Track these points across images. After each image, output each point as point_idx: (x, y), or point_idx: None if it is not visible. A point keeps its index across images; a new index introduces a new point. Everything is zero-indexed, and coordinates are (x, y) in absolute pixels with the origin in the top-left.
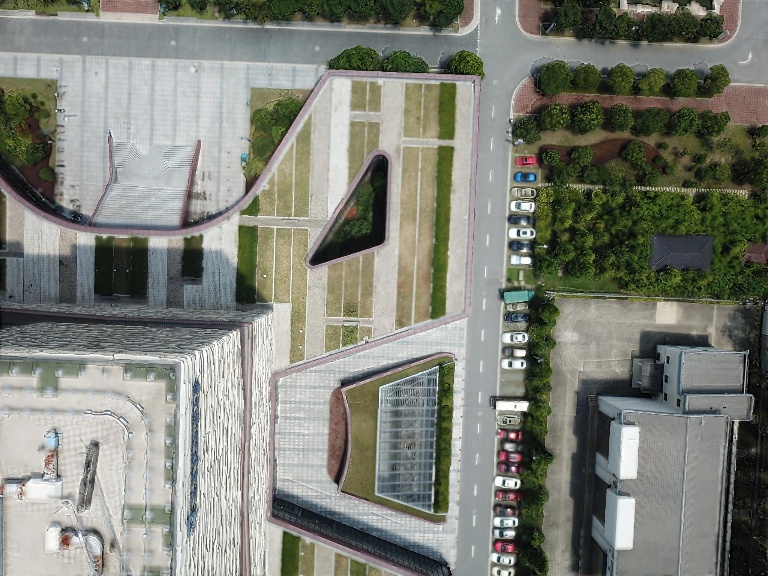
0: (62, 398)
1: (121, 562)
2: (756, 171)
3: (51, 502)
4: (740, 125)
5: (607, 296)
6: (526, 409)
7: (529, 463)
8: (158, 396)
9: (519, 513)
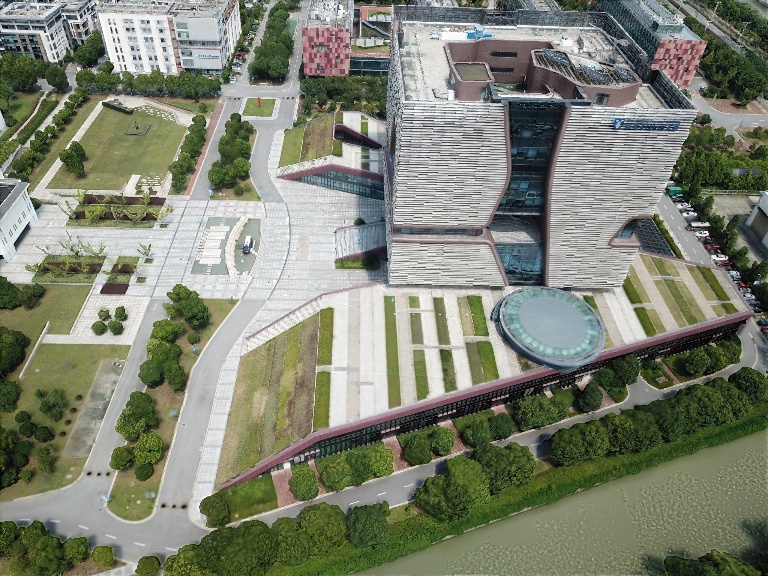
0: (563, 34)
1: (601, 55)
2: (759, 148)
3: (572, 42)
4: (741, 150)
5: (721, 194)
6: (709, 224)
7: (726, 245)
8: (595, 34)
9: (736, 268)
